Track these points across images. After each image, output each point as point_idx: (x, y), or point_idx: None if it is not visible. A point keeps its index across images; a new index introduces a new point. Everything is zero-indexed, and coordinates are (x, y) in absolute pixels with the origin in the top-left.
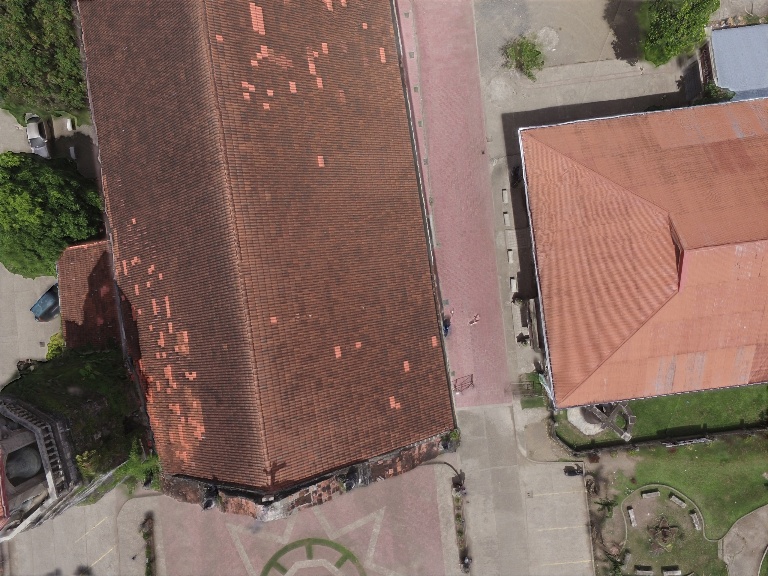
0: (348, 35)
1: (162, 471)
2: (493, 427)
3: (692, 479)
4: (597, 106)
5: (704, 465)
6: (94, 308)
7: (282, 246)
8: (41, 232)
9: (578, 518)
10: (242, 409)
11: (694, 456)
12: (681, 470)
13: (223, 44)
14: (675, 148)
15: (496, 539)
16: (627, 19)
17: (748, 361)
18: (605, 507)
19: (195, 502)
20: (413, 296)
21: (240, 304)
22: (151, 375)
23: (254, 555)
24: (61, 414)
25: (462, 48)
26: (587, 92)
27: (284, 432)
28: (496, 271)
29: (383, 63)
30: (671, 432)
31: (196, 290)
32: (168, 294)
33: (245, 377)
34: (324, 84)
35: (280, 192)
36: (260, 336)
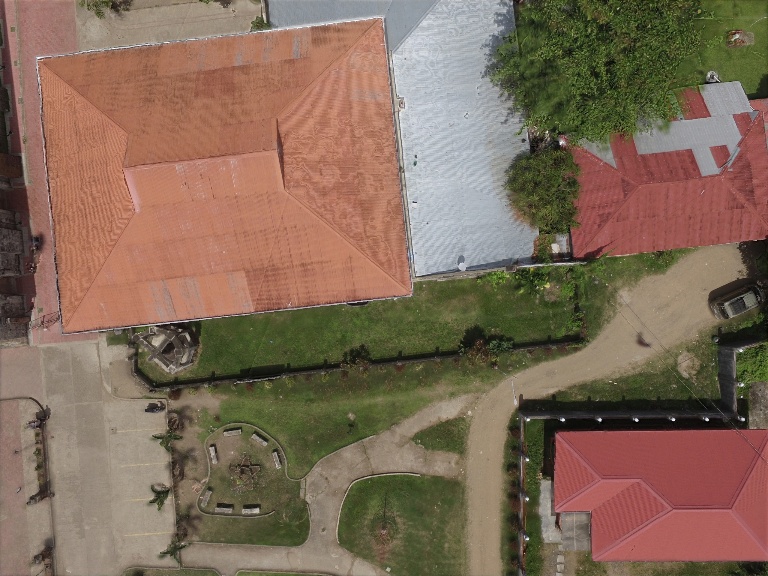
0: None
1: None
2: (79, 363)
3: (277, 418)
4: None
5: (289, 405)
6: None
7: None
8: None
9: (160, 455)
10: None
11: (278, 396)
12: (266, 409)
13: None
14: (170, 75)
15: (79, 474)
16: None
17: (244, 288)
18: None
19: None
20: None
21: None
22: None
23: None
24: None
25: None
26: (180, 33)
27: None
28: None
29: None
30: (255, 371)
31: None
32: None
33: None
34: None
35: None
36: None
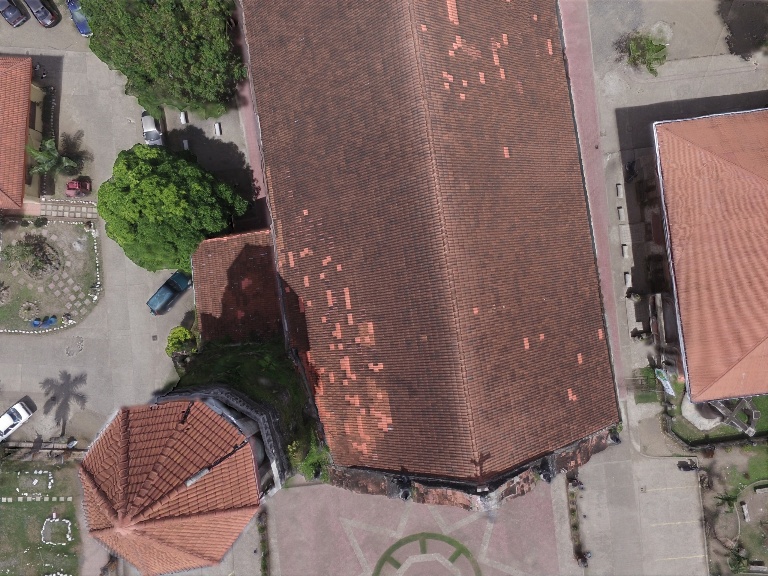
0: (522, 26)
1: (334, 463)
2: None
3: None
4: (711, 101)
5: None
6: (234, 301)
7: (480, 237)
8: (182, 224)
9: (691, 513)
10: (444, 400)
11: None
12: None
13: (427, 34)
14: None
15: (609, 534)
16: (741, 14)
17: None
18: (725, 502)
19: (377, 493)
20: (582, 288)
21: (447, 294)
22: (323, 367)
23: (368, 549)
24: (269, 404)
25: (576, 42)
26: (701, 87)
27: (487, 423)
28: (610, 266)
29: (550, 55)
30: None
31: (387, 281)
32: (349, 285)
33: (450, 368)
34: (506, 75)
35: (476, 183)
36: (466, 327)
